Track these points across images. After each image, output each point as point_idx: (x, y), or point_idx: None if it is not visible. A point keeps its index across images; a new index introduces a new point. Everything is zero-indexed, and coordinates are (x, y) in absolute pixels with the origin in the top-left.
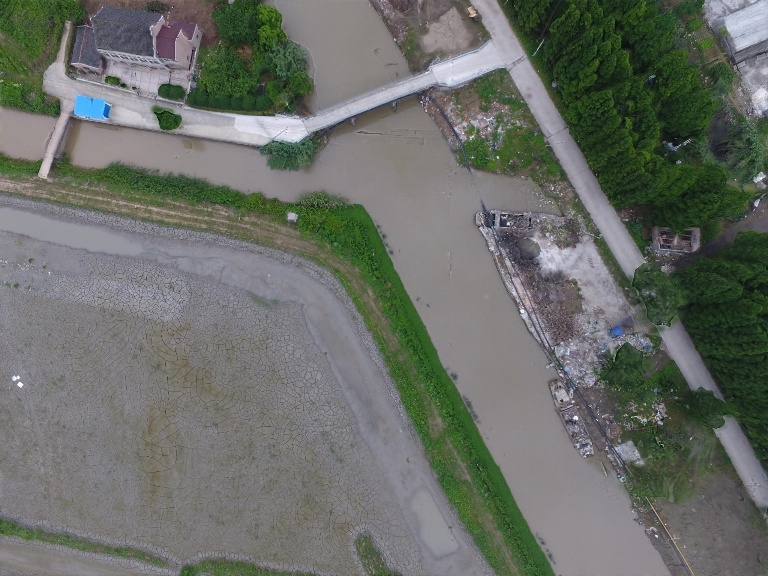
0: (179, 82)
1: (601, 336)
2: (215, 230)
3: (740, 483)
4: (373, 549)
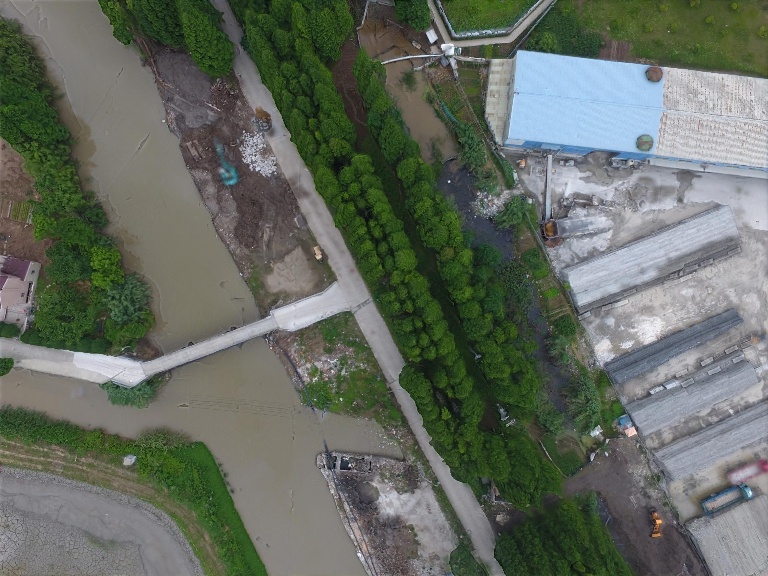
0: (17, 314)
1: None
2: (50, 472)
3: None
4: None
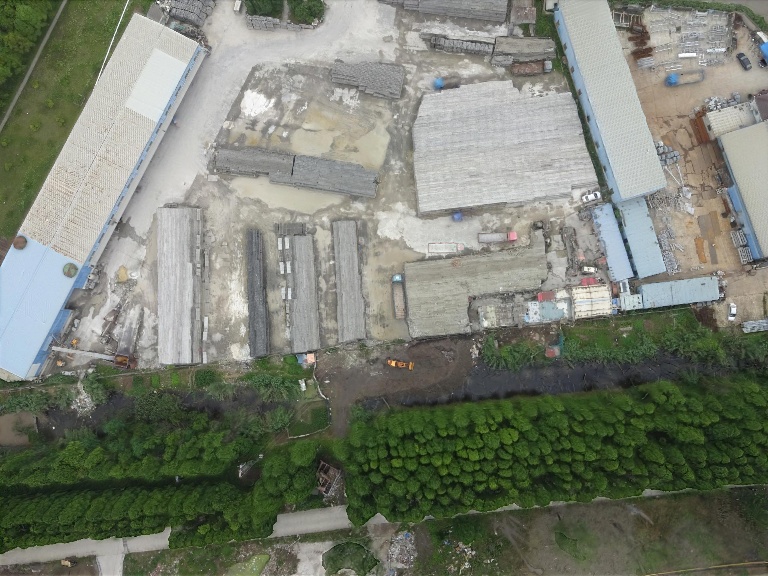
0: None
1: (382, 571)
2: None
3: (548, 509)
4: None
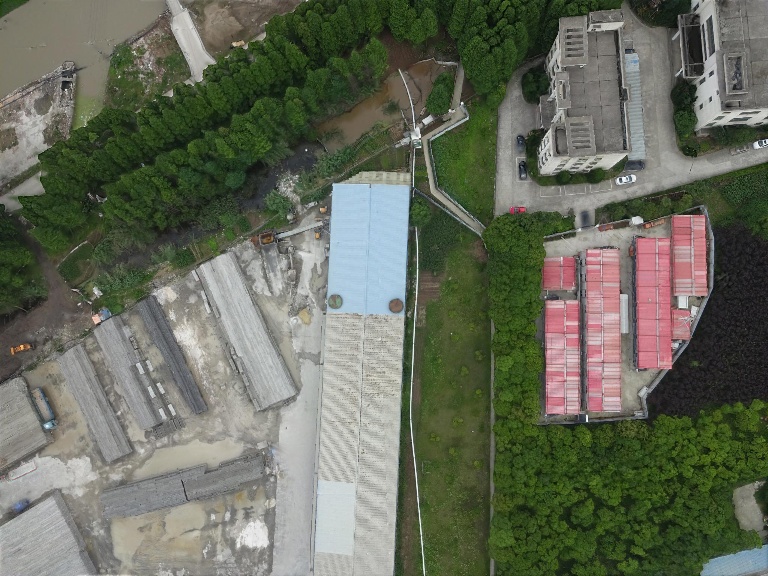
0: None
1: None
2: None
3: None
4: None
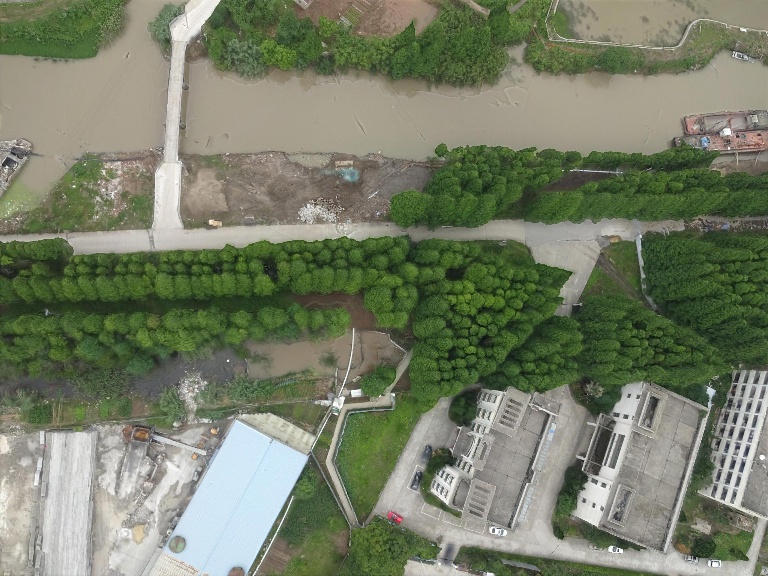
0: None
1: None
2: None
3: None
4: None
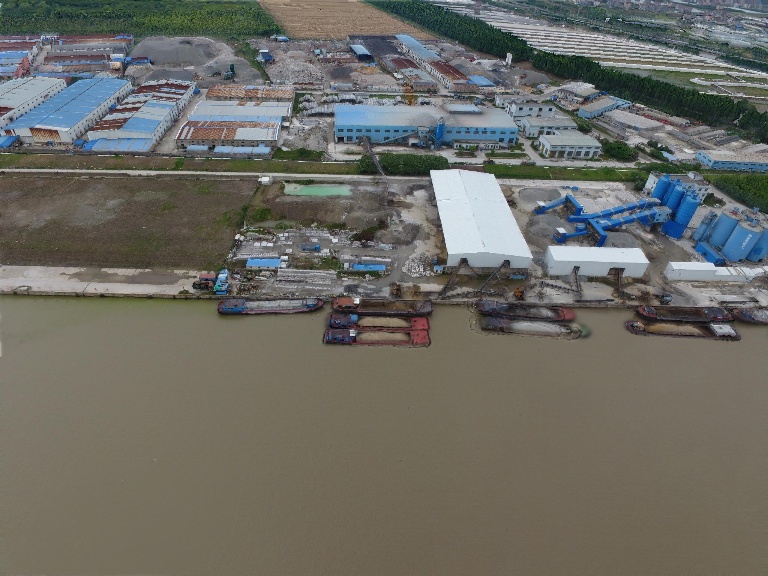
0: None
1: None
2: None
3: None
4: (751, 105)
